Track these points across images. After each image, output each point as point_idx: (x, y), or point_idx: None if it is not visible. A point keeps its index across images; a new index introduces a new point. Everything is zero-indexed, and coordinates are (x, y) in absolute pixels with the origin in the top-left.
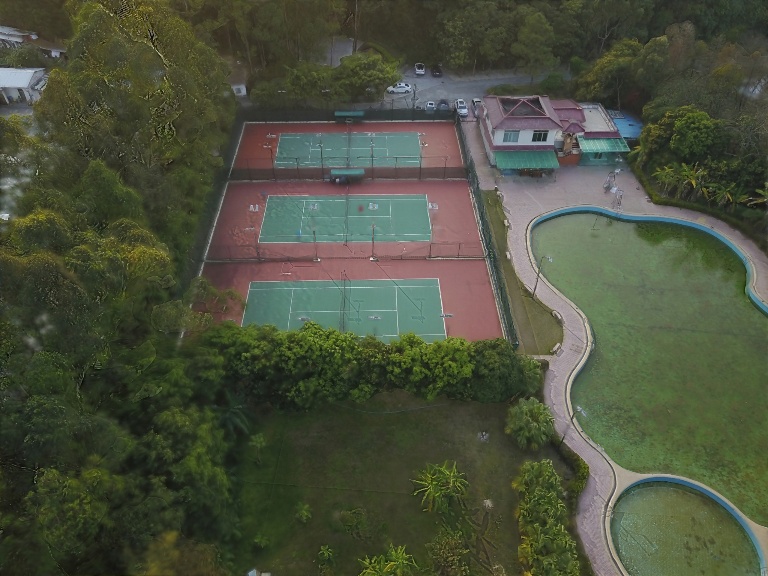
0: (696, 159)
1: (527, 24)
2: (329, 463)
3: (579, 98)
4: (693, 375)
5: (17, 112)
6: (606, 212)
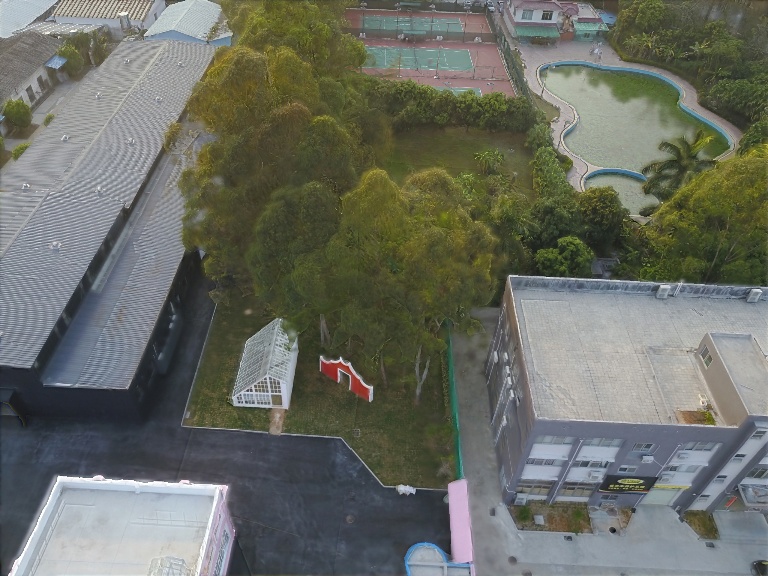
0: (652, 30)
1: None
2: (422, 156)
3: None
4: (639, 136)
5: None
6: (590, 65)
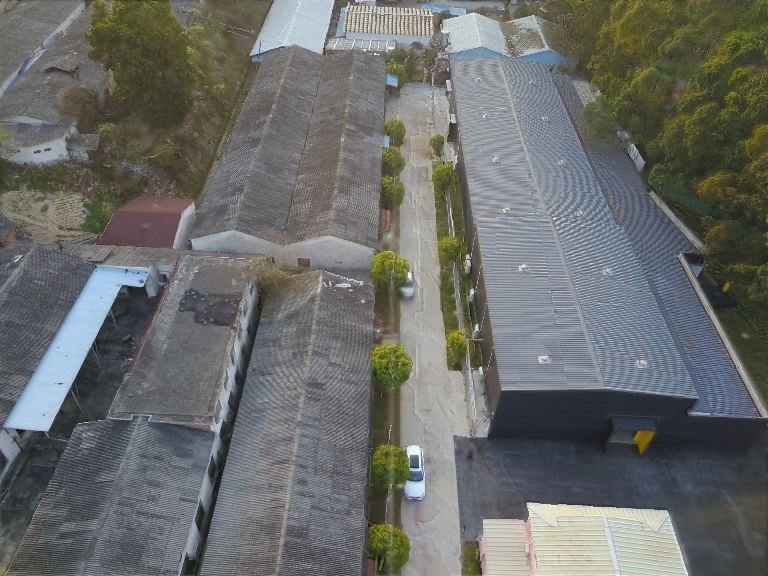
0: None
1: None
2: None
3: None
4: None
5: (413, 6)
6: None
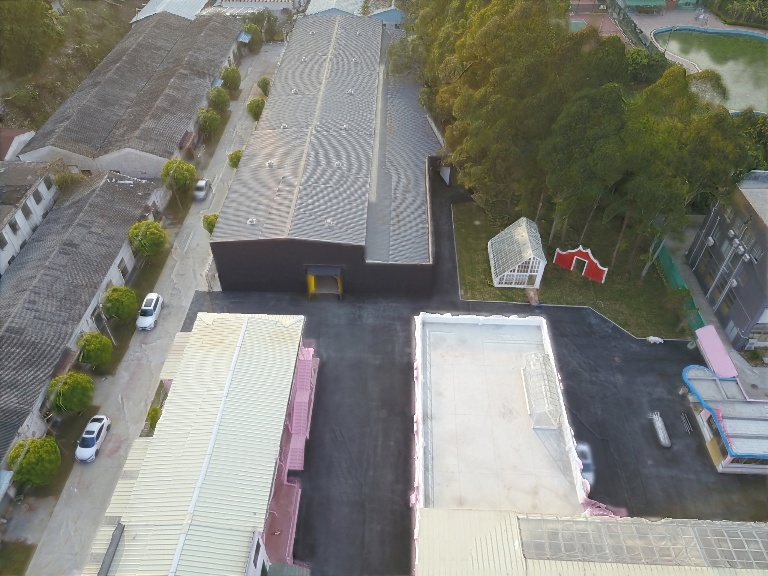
0: None
1: None
2: None
3: None
4: (759, 86)
5: None
6: (698, 29)
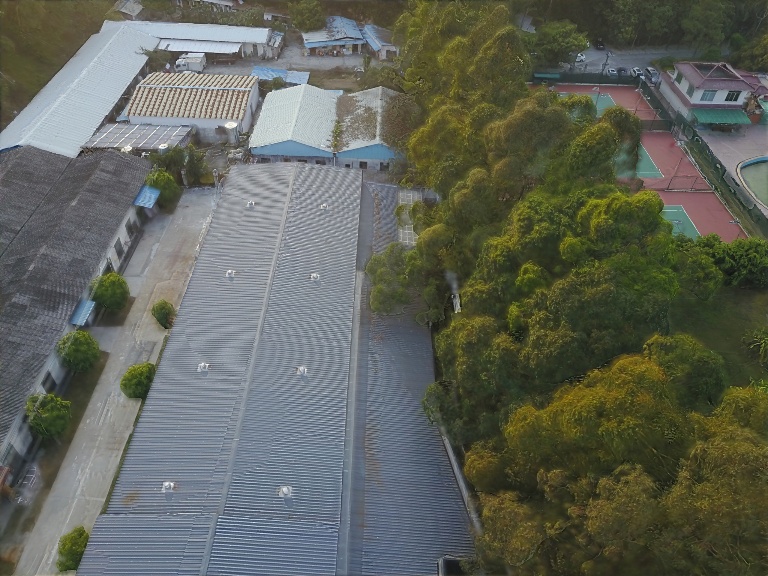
0: None
1: (701, 2)
2: None
3: (744, 69)
4: None
5: (254, 65)
6: None
